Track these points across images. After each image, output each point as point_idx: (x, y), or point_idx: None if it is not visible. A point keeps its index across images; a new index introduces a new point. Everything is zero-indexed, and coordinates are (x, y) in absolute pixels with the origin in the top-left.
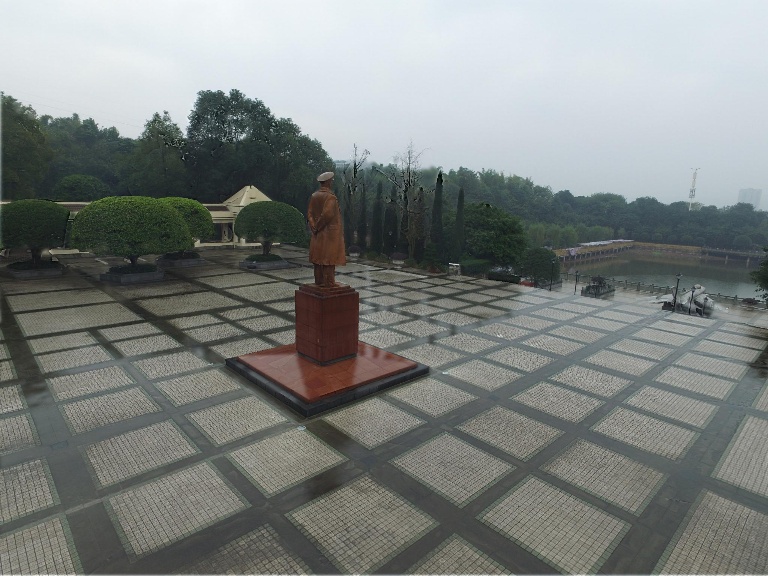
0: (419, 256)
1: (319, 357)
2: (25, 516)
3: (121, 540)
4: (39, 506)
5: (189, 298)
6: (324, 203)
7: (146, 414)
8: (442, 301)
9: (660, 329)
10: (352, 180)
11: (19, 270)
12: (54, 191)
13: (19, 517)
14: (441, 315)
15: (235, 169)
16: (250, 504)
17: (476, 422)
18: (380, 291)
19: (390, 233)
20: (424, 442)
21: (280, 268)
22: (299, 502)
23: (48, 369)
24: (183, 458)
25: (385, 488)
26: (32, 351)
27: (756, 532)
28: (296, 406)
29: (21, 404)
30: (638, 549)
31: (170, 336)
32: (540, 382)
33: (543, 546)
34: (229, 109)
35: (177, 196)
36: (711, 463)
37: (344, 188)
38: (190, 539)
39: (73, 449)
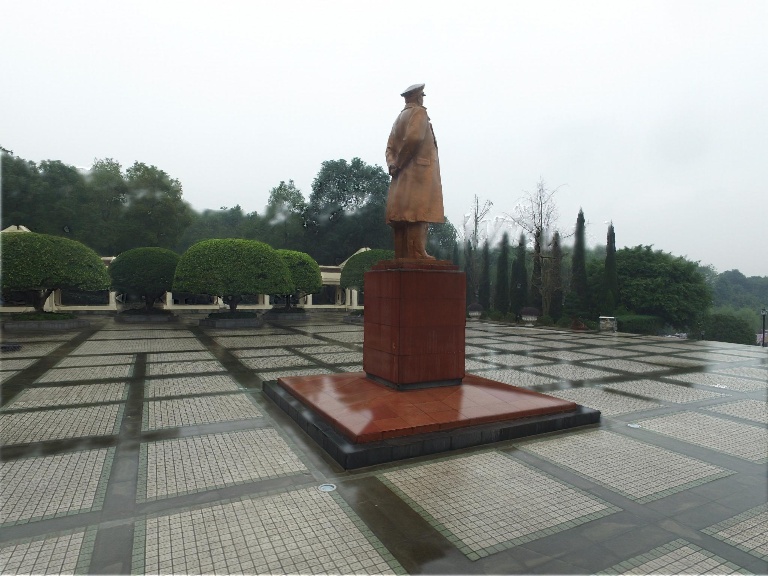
0: (556, 314)
1: (394, 375)
2: None
3: None
4: None
5: (272, 337)
6: (408, 121)
7: (87, 436)
8: (598, 349)
9: None
10: (473, 234)
11: (130, 315)
12: None
13: None
14: (601, 361)
15: (352, 231)
16: None
17: (761, 525)
18: (506, 339)
19: (518, 286)
20: (626, 560)
21: None
22: None
23: (45, 380)
24: (53, 516)
25: None
26: (55, 365)
27: None
28: (332, 446)
29: None
30: None
31: (220, 362)
32: None
33: None
34: (351, 179)
35: None
36: None
37: (464, 242)
38: None
39: None
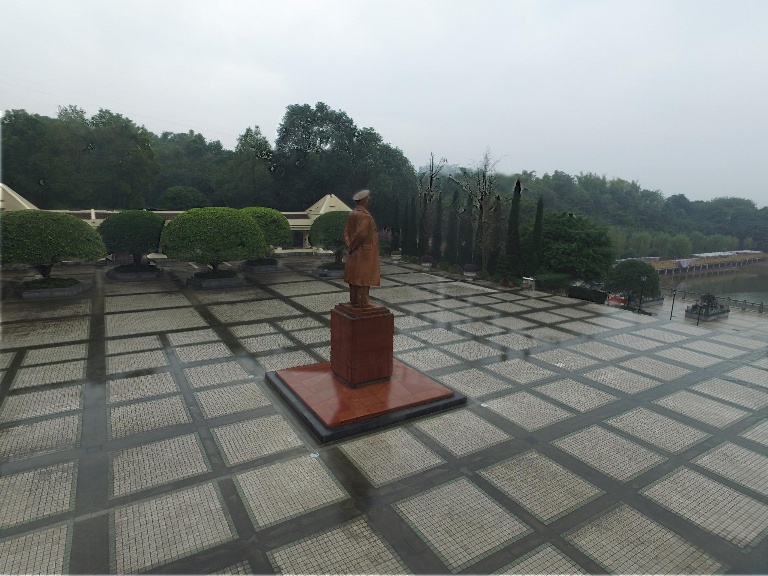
0: (493, 268)
1: (349, 379)
2: (41, 519)
3: (110, 557)
4: (56, 510)
5: (255, 305)
6: (358, 222)
7: (177, 424)
8: (505, 320)
9: (765, 368)
10: (428, 188)
11: (122, 273)
12: (159, 201)
13: (36, 519)
14: (499, 336)
15: (317, 179)
16: (237, 535)
17: (502, 468)
18: (442, 305)
19: (463, 243)
20: (436, 486)
21: None
22: (285, 540)
23: (112, 371)
24: (193, 475)
25: (378, 536)
26: (106, 352)
27: None
28: (315, 430)
29: (78, 404)
30: None
31: (225, 344)
32: (592, 425)
33: None
34: (315, 121)
35: (264, 205)
36: None
37: (420, 197)
38: (170, 566)
39: (103, 454)
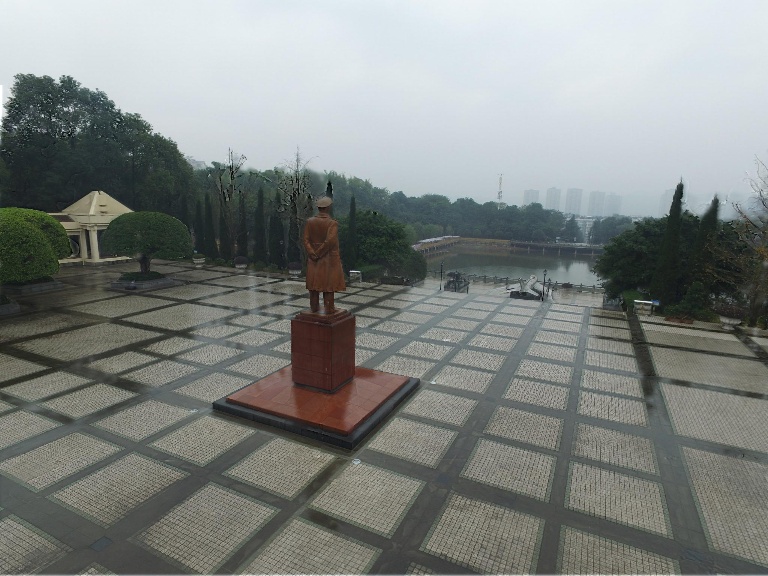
0: None
1: (327, 386)
2: None
3: None
4: None
5: (86, 334)
6: (328, 230)
7: (175, 482)
8: (369, 310)
9: (555, 319)
10: (229, 186)
11: None
12: None
13: None
14: (381, 325)
15: (77, 171)
16: (379, 549)
17: (496, 424)
18: (301, 305)
19: (281, 242)
20: (472, 451)
21: (166, 287)
22: (421, 534)
23: None
24: (268, 521)
25: (478, 501)
26: None
27: (727, 469)
28: (336, 440)
29: None
30: (679, 501)
31: (109, 384)
32: (512, 379)
33: (625, 516)
34: (57, 98)
35: None
36: (668, 424)
37: (220, 195)
38: None
39: (124, 544)
